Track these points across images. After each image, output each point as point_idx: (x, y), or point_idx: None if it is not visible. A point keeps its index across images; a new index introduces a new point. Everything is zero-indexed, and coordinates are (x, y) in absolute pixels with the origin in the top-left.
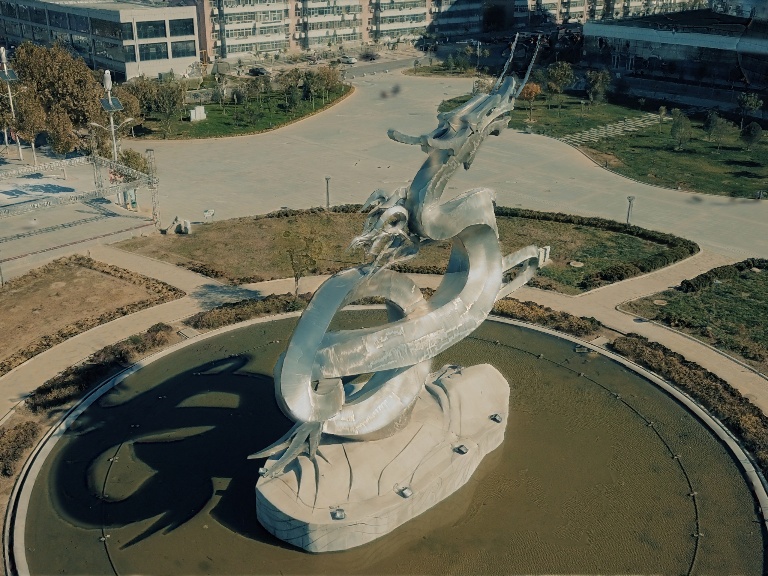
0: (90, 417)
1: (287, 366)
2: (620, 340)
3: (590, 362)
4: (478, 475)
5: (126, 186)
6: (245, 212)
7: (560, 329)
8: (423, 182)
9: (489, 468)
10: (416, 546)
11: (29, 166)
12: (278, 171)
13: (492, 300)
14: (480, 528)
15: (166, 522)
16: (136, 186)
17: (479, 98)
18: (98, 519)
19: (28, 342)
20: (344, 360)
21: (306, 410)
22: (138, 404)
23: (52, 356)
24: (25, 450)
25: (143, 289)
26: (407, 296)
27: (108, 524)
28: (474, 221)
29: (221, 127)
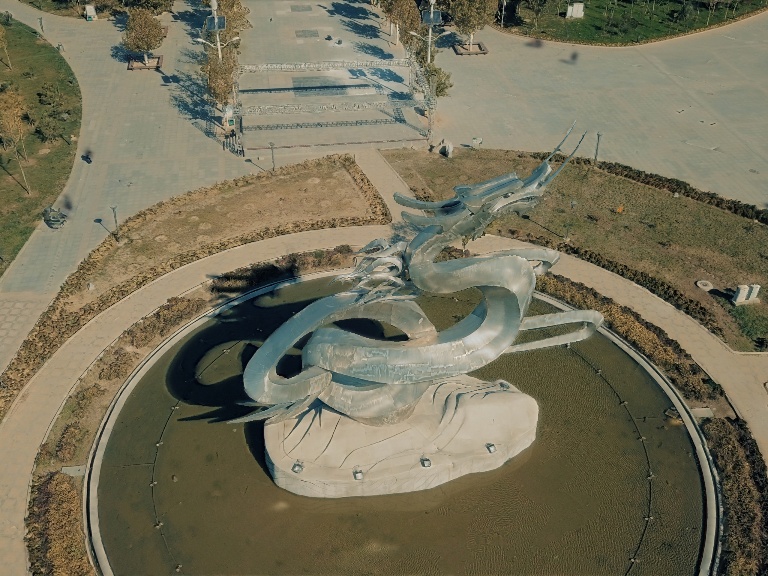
0: (240, 310)
1: (257, 355)
2: (717, 421)
3: (666, 430)
4: (456, 486)
5: (406, 103)
6: (518, 145)
7: (674, 383)
8: (417, 244)
9: (476, 484)
10: (346, 518)
11: (354, 61)
12: (594, 101)
13: (498, 352)
14: (402, 530)
15: (217, 414)
16: (415, 104)
17: (504, 178)
18: (183, 392)
19: (254, 229)
20: (336, 359)
21: (258, 392)
22: (277, 312)
23: (258, 247)
24: (184, 320)
25: (367, 205)
26: (413, 325)
27: (186, 398)
28: (486, 282)
29: (589, 31)
